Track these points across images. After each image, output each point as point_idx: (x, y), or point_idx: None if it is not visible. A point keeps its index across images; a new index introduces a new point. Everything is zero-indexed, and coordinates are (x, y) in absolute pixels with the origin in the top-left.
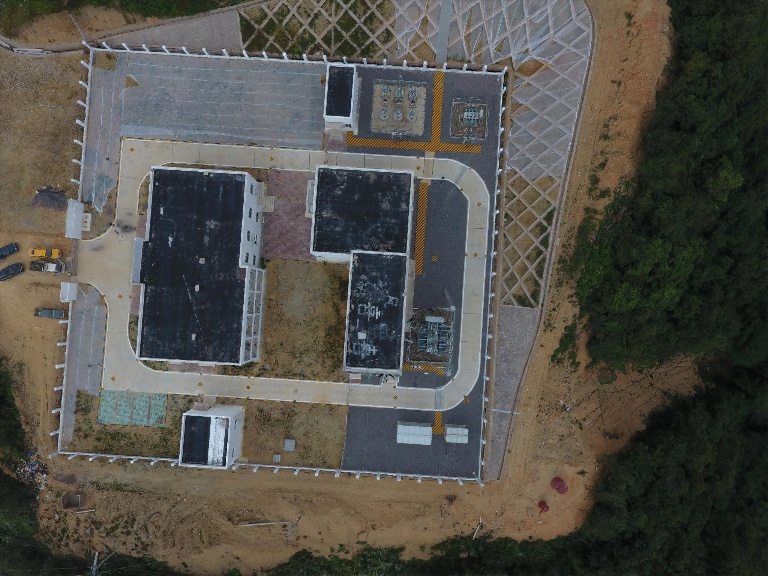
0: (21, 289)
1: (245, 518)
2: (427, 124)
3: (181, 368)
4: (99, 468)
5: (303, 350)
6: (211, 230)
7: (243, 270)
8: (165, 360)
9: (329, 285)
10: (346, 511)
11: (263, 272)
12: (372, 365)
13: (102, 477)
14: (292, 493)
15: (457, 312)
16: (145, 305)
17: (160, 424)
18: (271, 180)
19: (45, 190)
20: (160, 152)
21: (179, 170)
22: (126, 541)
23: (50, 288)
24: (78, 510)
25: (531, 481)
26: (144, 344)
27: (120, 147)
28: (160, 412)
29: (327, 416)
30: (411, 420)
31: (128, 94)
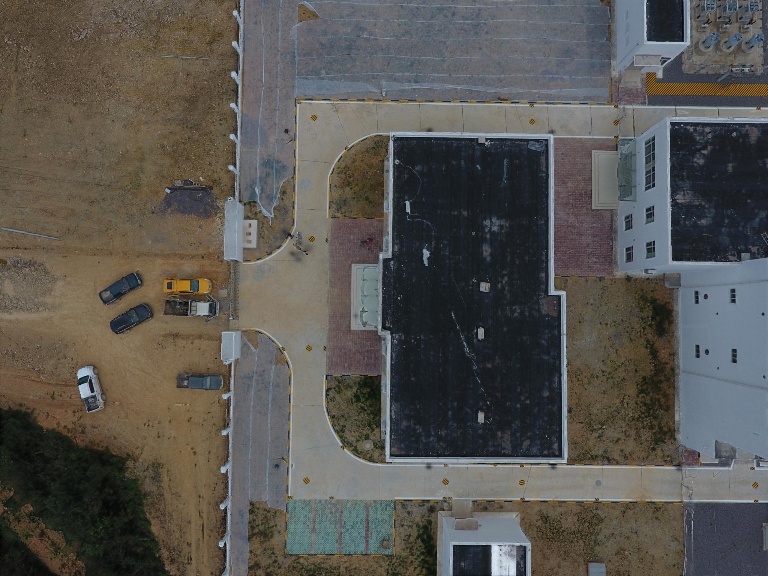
0: (149, 345)
1: None
2: (767, 57)
3: None
4: None
5: (604, 418)
6: (493, 234)
7: (552, 299)
8: (437, 461)
9: (637, 313)
10: None
11: None
12: None
13: None
14: None
15: None
16: (391, 367)
17: (386, 549)
18: None
19: (181, 187)
20: (358, 119)
21: (435, 137)
22: None
23: (197, 341)
24: None
25: None
26: (393, 433)
27: (295, 114)
28: (384, 530)
29: (651, 521)
30: None
31: (303, 32)
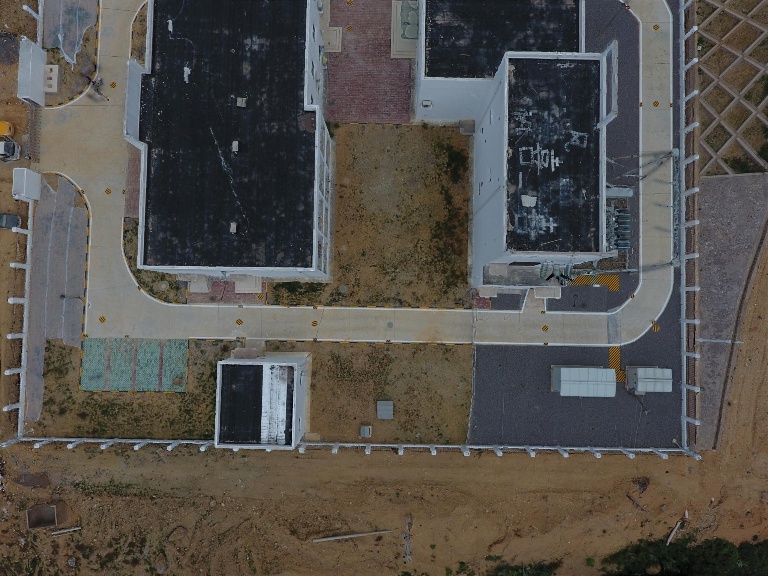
0: None
1: (317, 529)
2: None
3: (208, 298)
4: (85, 461)
5: (398, 261)
6: (254, 53)
7: (310, 116)
8: (187, 267)
9: (433, 159)
10: (478, 510)
11: (330, 143)
12: (550, 250)
13: (90, 475)
14: (392, 486)
15: (633, 192)
16: (149, 180)
17: (179, 387)
18: (335, 4)
19: None
20: None
21: None
22: (132, 575)
23: None
24: (54, 529)
25: (765, 449)
26: (150, 245)
27: None
28: (178, 368)
29: (440, 362)
30: (572, 362)
31: None
